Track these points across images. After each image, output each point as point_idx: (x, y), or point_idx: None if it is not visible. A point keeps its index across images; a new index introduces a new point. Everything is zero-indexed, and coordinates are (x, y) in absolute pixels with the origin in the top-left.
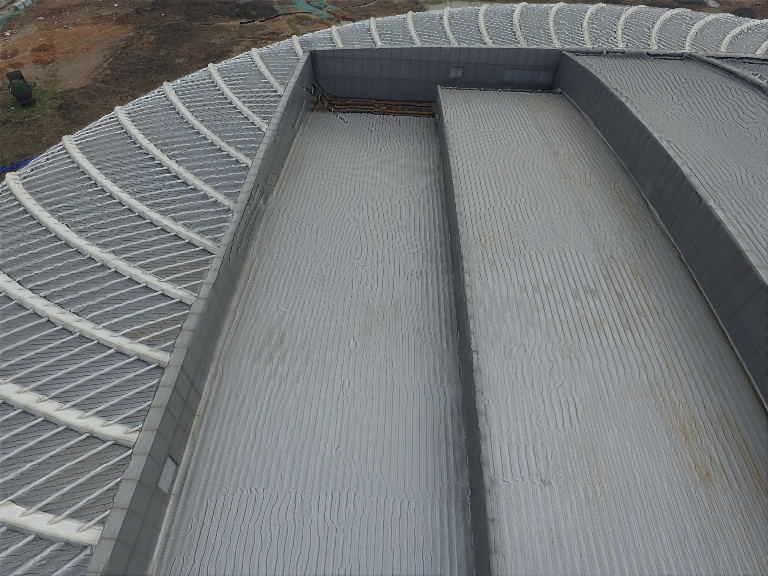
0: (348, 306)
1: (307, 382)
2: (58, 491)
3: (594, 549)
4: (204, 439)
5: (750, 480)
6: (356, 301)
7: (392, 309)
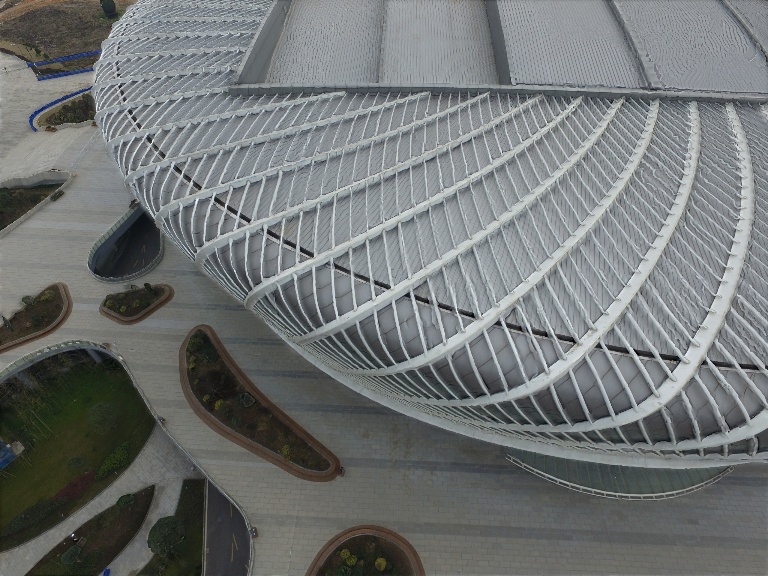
0: (344, 3)
1: None
2: (255, 3)
3: (416, 7)
4: (295, 10)
5: (470, 2)
6: (348, 1)
7: (363, 3)
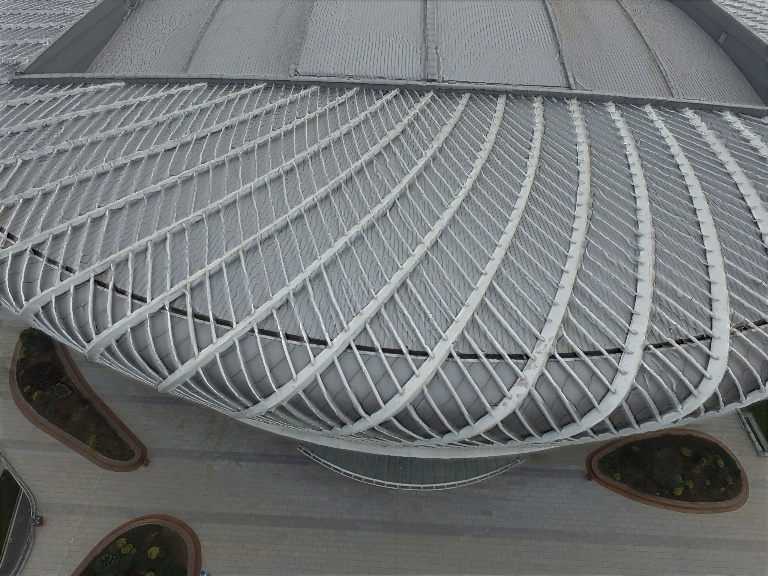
0: None
1: (186, 8)
2: None
3: (251, 1)
4: (143, 4)
5: None
6: None
7: None
